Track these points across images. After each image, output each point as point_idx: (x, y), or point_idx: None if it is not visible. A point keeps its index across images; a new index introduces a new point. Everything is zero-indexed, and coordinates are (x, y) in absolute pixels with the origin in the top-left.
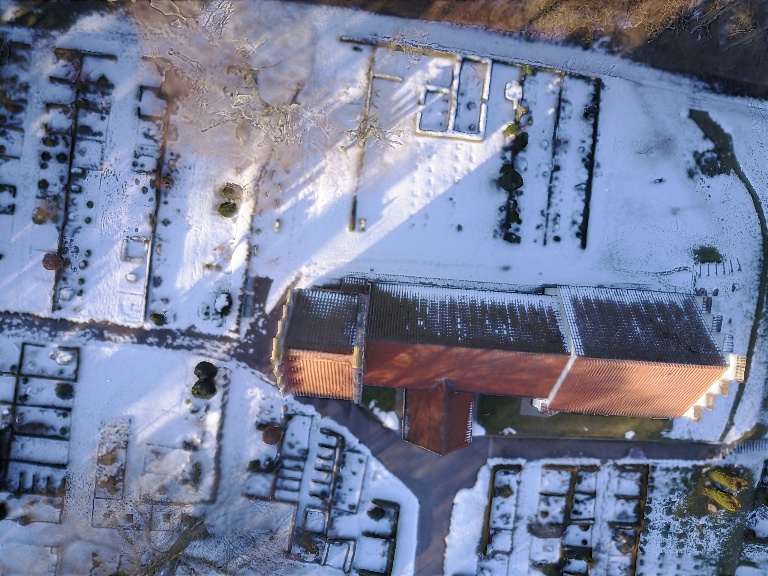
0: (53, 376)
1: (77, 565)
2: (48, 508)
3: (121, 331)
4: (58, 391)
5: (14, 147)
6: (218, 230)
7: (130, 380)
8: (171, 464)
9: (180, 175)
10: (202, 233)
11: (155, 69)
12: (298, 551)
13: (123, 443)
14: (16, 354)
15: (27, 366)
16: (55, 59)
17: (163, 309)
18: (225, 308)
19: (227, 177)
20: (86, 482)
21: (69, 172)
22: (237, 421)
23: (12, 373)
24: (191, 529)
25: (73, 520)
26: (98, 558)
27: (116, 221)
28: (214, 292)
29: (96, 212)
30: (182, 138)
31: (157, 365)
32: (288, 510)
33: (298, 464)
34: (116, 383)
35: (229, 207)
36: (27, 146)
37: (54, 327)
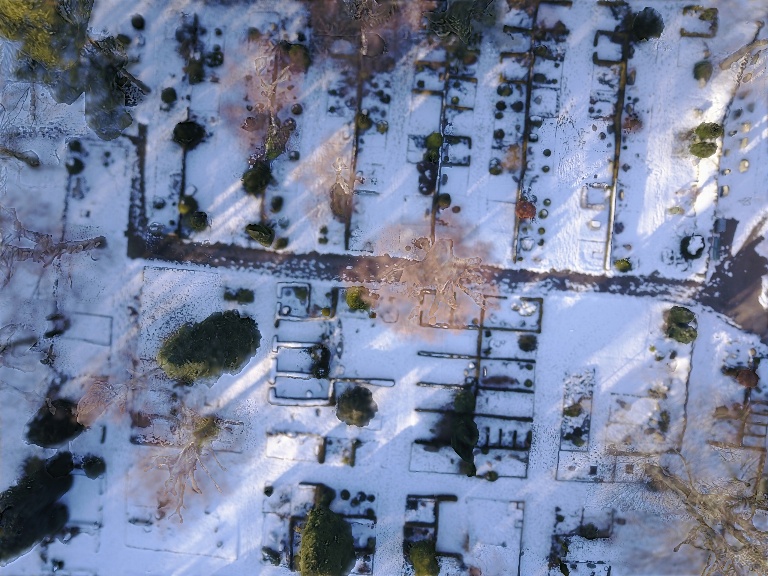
0: (516, 328)
1: (541, 520)
2: (514, 462)
3: (582, 279)
4: (521, 343)
5: (466, 98)
6: (678, 173)
7: (593, 329)
8: (636, 413)
9: (638, 119)
10: (662, 177)
11: (610, 13)
12: (763, 498)
13: (589, 393)
14: (476, 307)
15: (491, 318)
16: (508, 8)
17: (625, 255)
18: (699, 250)
19: (686, 119)
20: (551, 435)
21: (525, 121)
22: (703, 367)
23: (476, 326)
24: (743, 467)
25: (537, 474)
26: (561, 512)
27: (574, 168)
28: (678, 236)
29: (553, 160)
30: (639, 82)
31: (620, 313)
32: (753, 456)
33: (766, 408)
34: (579, 332)
35: (710, 146)
36: (480, 97)
37: (514, 278)
